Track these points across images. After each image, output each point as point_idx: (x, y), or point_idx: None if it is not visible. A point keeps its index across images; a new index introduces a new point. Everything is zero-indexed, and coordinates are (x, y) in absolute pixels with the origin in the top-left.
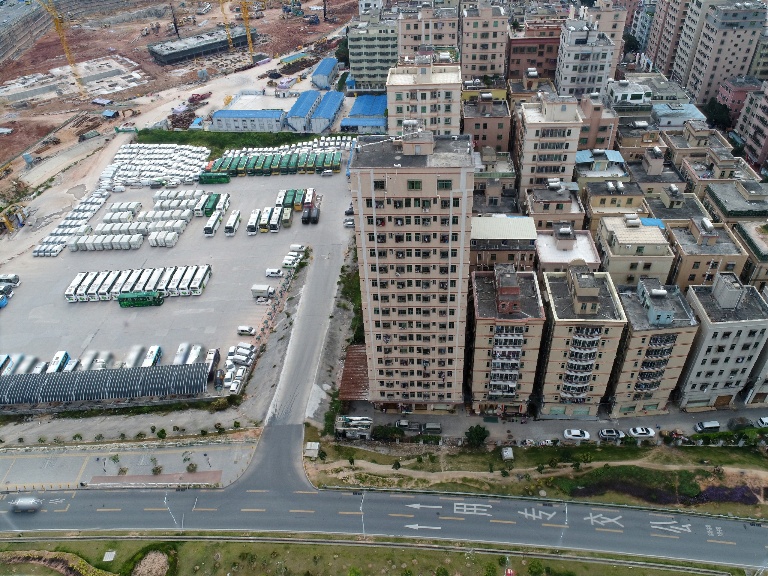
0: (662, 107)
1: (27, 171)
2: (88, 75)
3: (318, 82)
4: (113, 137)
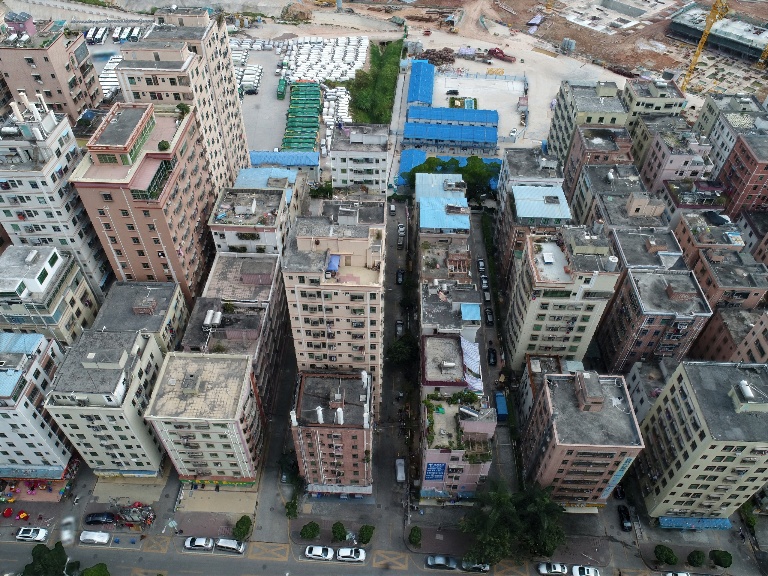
0: (21, 344)
1: None
2: (618, 0)
3: None
4: (392, 30)
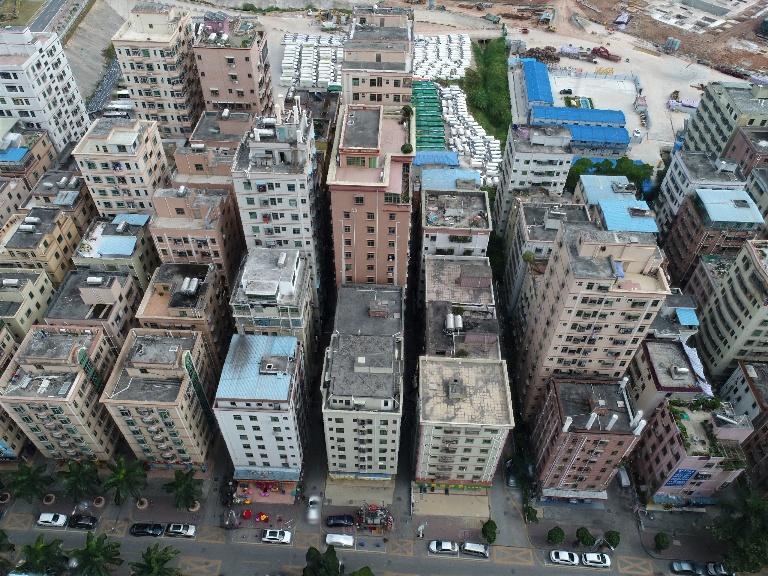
0: (279, 347)
1: None
2: None
3: None
4: (490, 28)
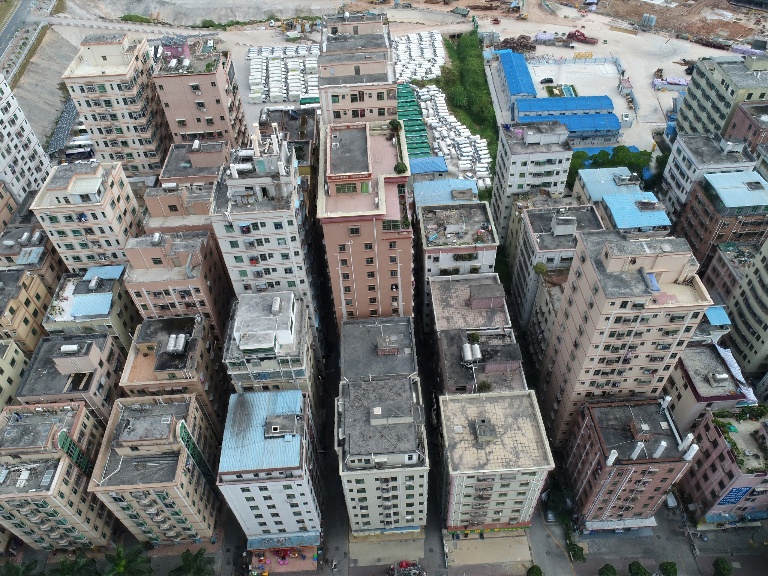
0: (283, 404)
1: (388, 8)
2: None
3: (679, 105)
4: (460, 22)
